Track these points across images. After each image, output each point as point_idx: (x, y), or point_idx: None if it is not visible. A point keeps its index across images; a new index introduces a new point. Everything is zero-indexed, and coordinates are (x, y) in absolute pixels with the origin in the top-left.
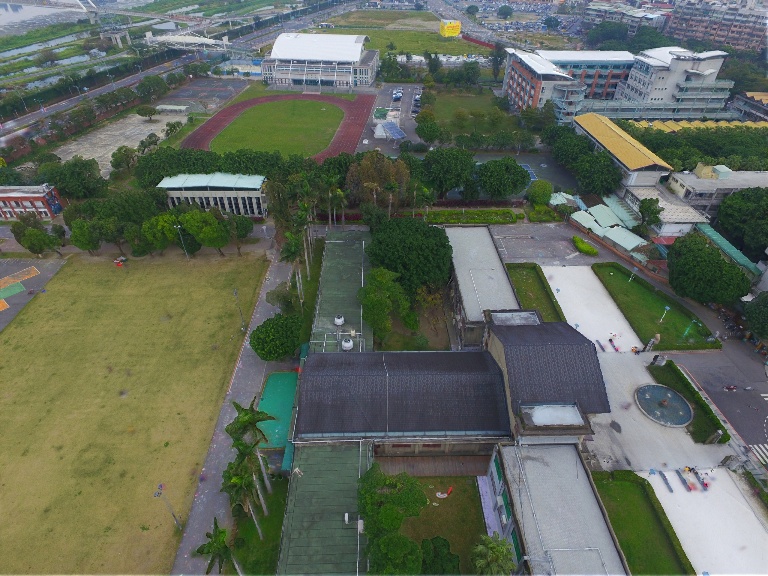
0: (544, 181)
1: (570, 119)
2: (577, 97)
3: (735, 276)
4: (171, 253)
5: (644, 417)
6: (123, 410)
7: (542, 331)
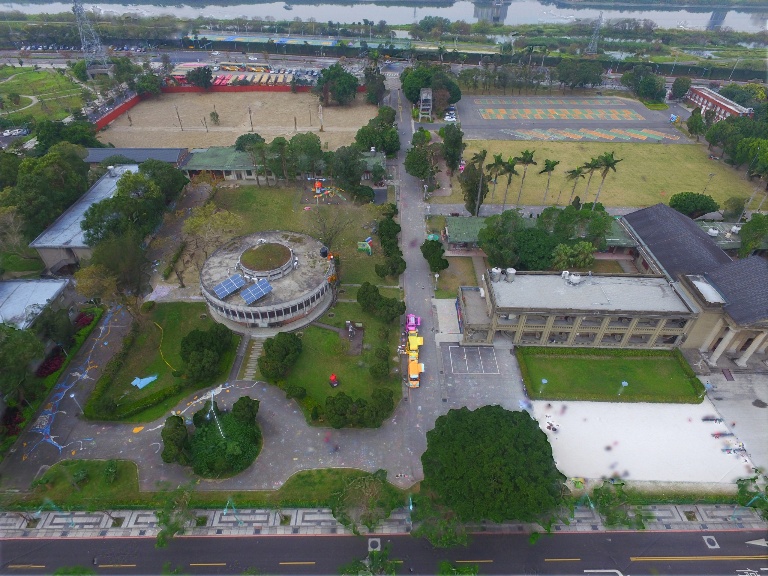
0: None
1: None
2: None
3: None
4: (744, 172)
5: None
6: (605, 180)
7: None
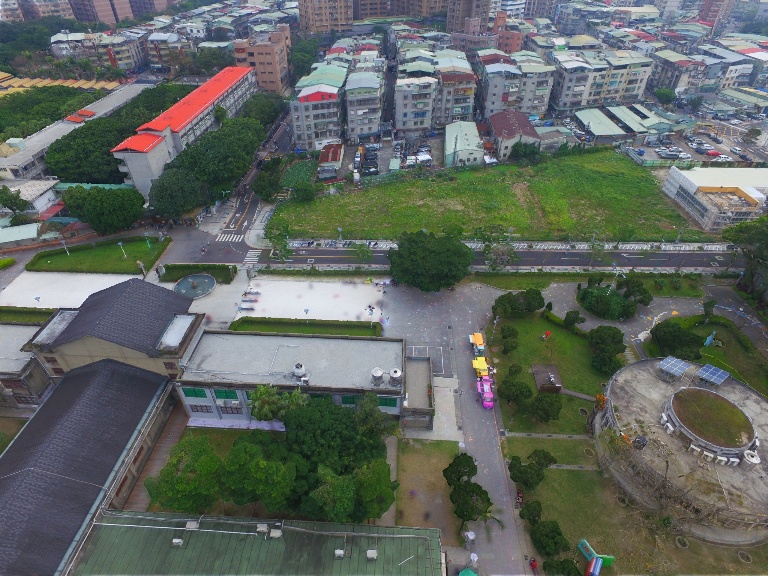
0: None
1: None
2: None
3: (129, 193)
4: None
5: (198, 300)
6: None
7: (91, 309)
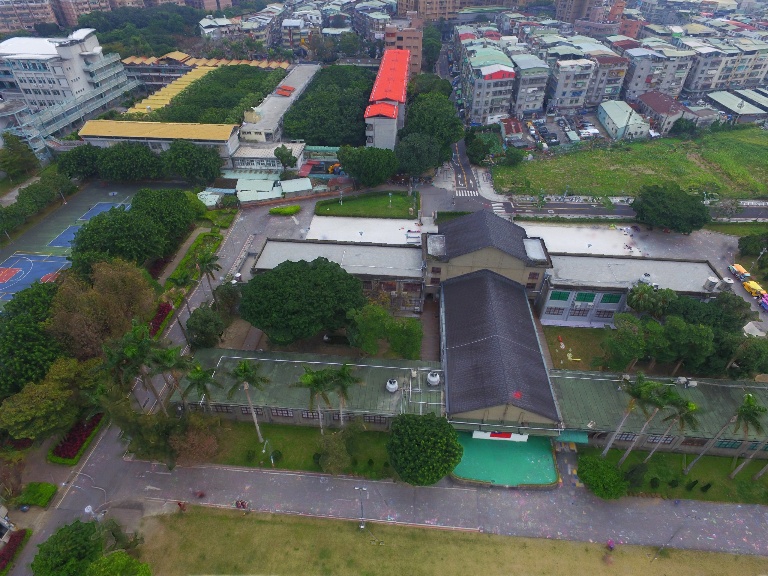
0: (185, 192)
1: (42, 144)
2: (30, 117)
3: None
4: None
5: None
6: None
7: (460, 232)
